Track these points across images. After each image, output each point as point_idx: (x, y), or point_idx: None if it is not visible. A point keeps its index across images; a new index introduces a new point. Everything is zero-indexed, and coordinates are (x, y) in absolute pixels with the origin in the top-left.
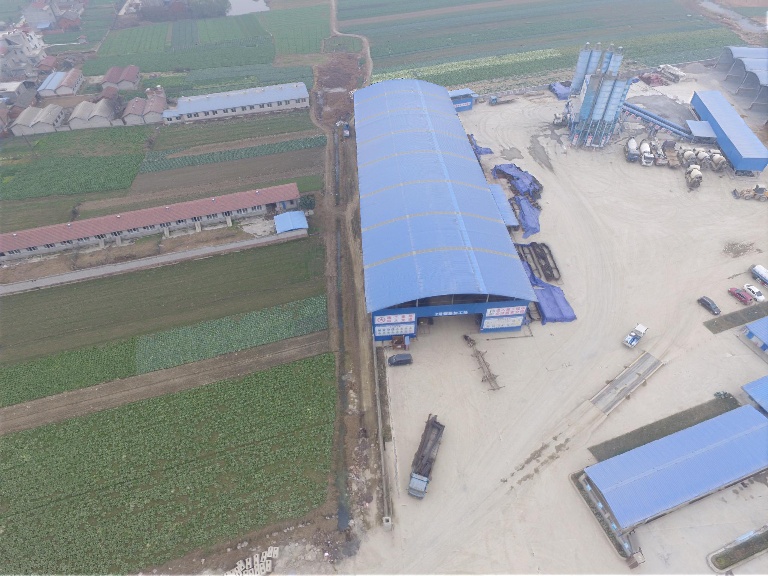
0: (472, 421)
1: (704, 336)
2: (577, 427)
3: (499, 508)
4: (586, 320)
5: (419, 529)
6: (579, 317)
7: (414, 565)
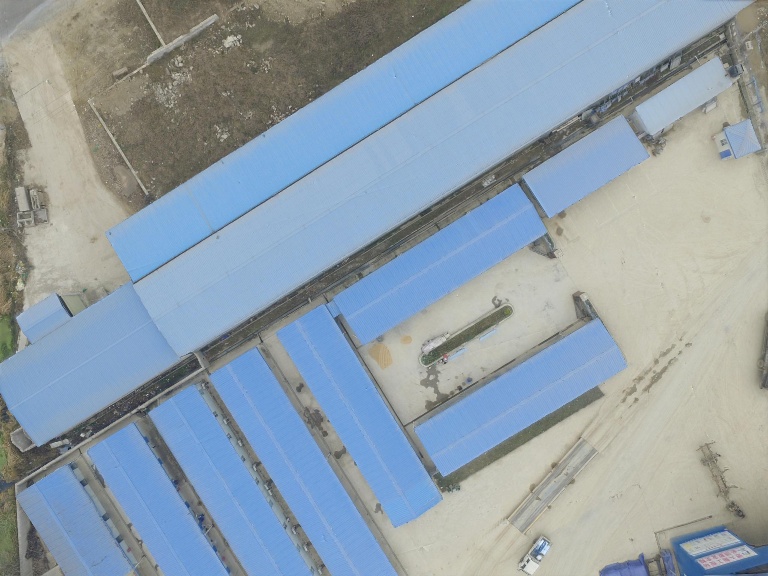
0: (724, 402)
1: (448, 572)
2: (613, 417)
3: (693, 318)
4: (587, 572)
5: (766, 283)
6: (596, 575)
7: (767, 253)
